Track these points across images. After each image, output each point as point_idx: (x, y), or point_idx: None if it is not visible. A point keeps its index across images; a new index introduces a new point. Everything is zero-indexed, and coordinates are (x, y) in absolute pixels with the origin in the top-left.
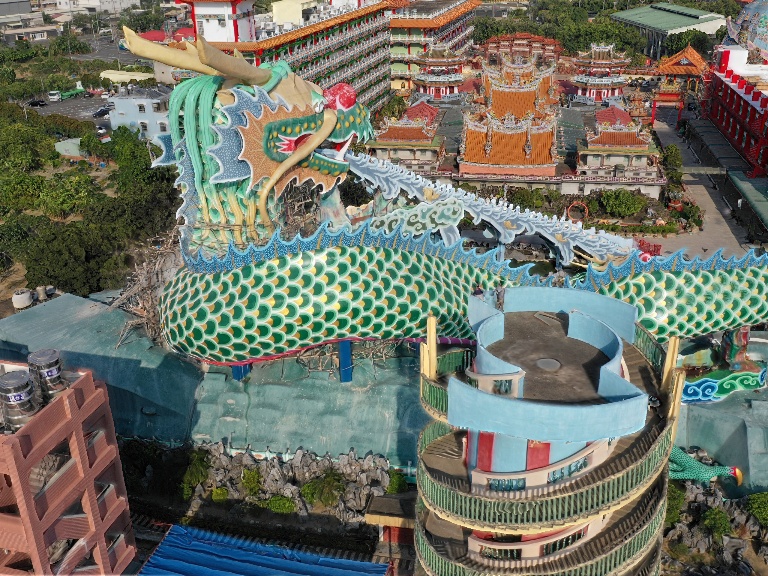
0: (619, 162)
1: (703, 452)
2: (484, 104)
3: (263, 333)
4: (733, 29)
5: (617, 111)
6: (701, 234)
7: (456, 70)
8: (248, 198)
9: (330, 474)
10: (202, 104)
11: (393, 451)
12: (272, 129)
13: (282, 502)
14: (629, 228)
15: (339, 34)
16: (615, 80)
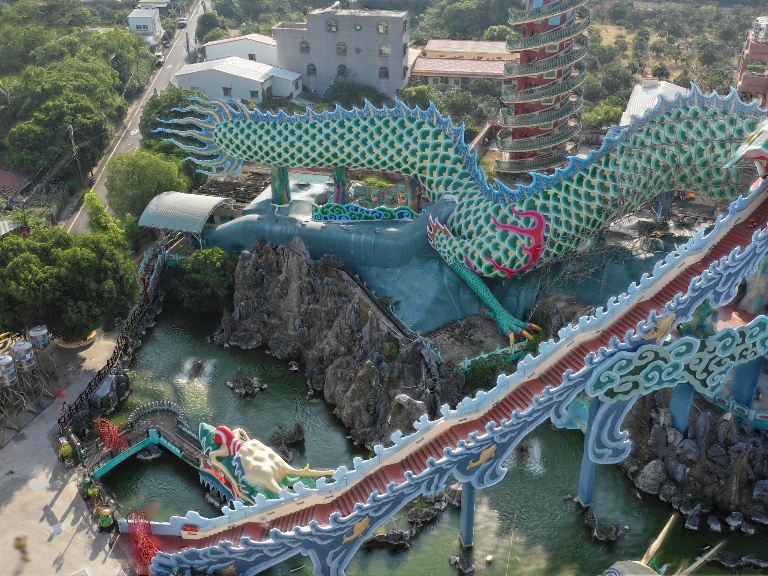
0: None
1: None
2: None
3: None
4: None
5: None
6: None
7: None
8: None
9: None
10: None
11: None
12: None
13: None
14: None
15: None
16: None
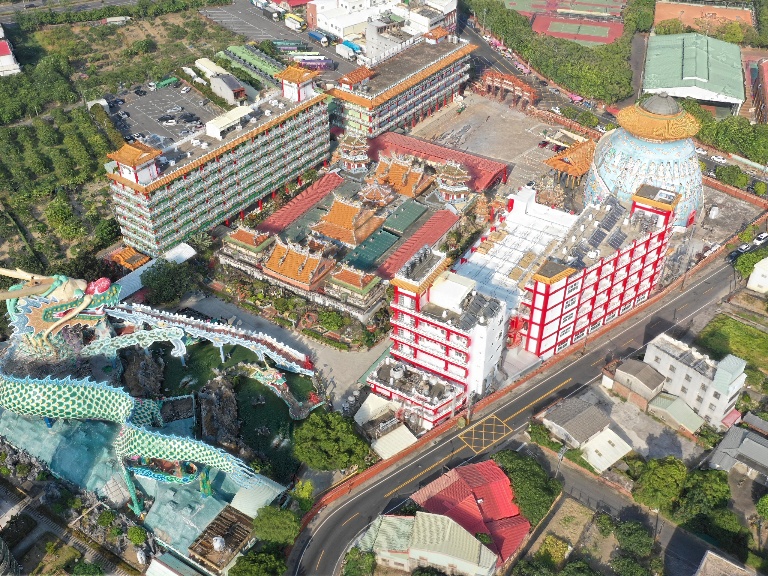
0: (349, 291)
1: (149, 502)
2: None
3: (8, 408)
4: None
5: (448, 215)
6: (364, 354)
7: (442, 103)
8: (36, 337)
9: (31, 463)
10: (11, 304)
11: (50, 463)
12: (48, 311)
13: (4, 471)
14: (324, 340)
15: (248, 145)
16: (458, 189)
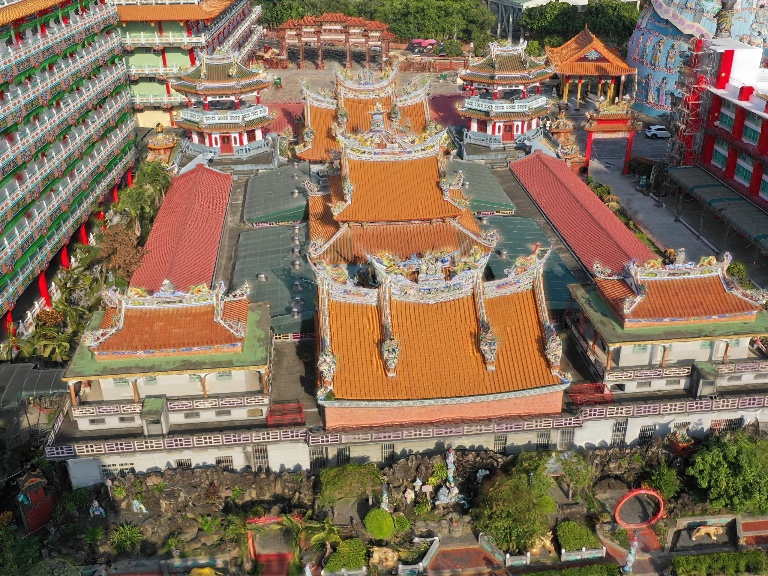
0: (691, 351)
1: None
2: (315, 162)
3: None
4: (664, 5)
5: (548, 161)
6: None
7: None
8: None
9: None
10: None
11: None
12: None
13: None
14: None
15: None
16: (533, 104)
